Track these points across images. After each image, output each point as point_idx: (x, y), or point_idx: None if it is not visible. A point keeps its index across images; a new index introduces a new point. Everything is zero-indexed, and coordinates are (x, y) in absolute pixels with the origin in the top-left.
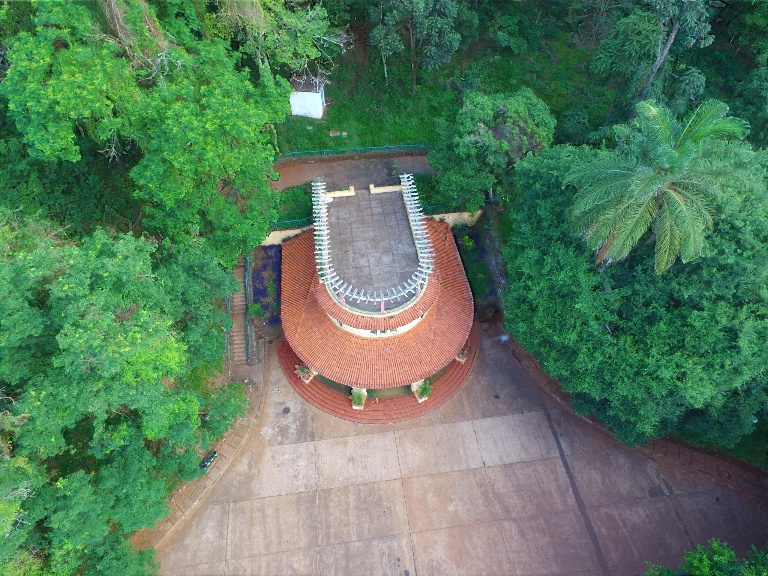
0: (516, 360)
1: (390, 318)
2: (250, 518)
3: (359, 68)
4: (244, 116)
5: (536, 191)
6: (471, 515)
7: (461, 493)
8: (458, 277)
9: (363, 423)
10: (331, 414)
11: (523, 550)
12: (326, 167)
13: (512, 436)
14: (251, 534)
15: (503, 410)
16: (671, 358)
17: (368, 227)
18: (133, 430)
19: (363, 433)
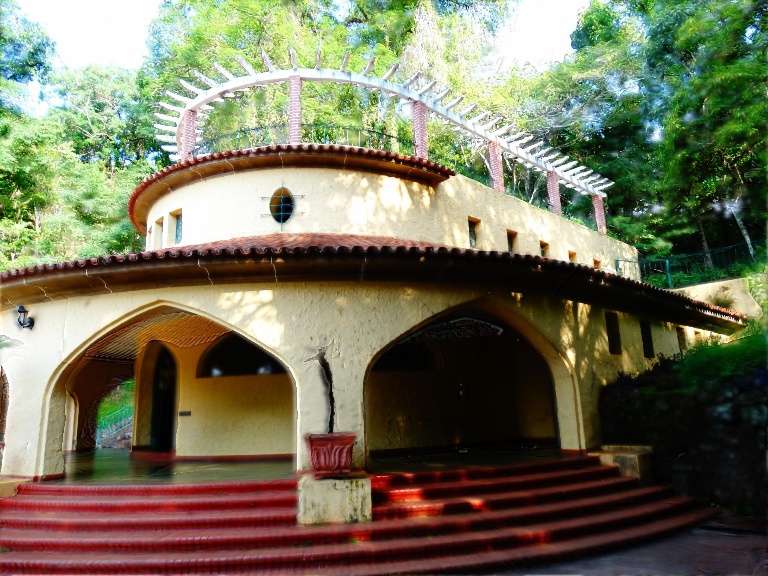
0: None
1: None
2: None
3: None
4: None
5: None
6: None
7: None
8: None
9: None
10: None
11: None
12: None
13: None
14: None
15: None
16: None
17: None
18: None
19: None
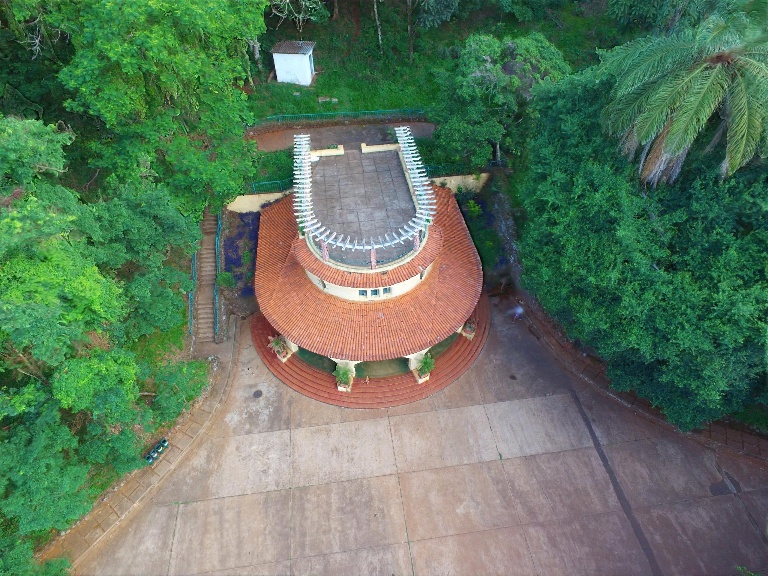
0: (534, 337)
1: (383, 274)
2: (203, 523)
3: (352, 38)
4: (200, 3)
5: (558, 110)
6: (486, 519)
7: (473, 491)
8: (463, 241)
9: (350, 408)
10: (312, 398)
11: (555, 563)
12: (313, 132)
13: (534, 422)
14: (203, 544)
15: (521, 392)
16: (748, 292)
17: (358, 184)
18: (42, 394)
19: (350, 419)
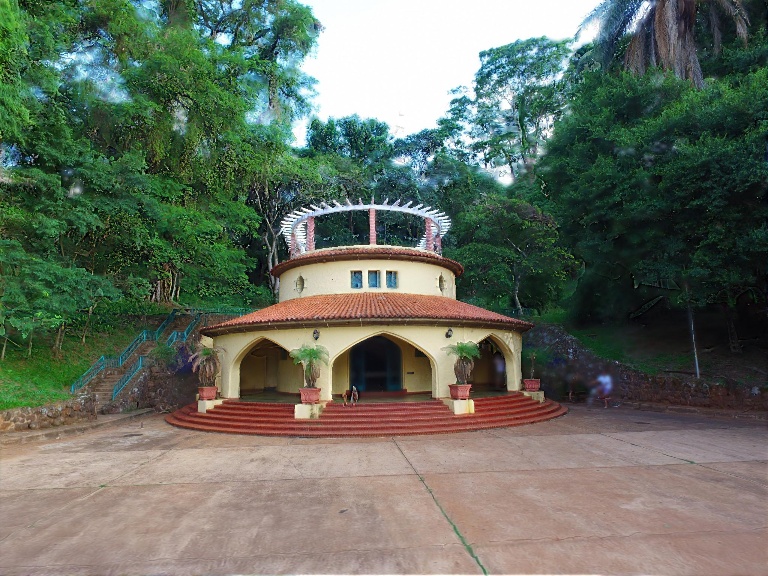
0: (650, 411)
1: None
2: None
3: None
4: None
5: None
6: (741, 513)
7: (651, 487)
8: None
9: (314, 437)
10: (238, 432)
11: None
12: None
13: (730, 440)
14: None
15: (670, 427)
16: None
17: None
18: None
19: (309, 442)
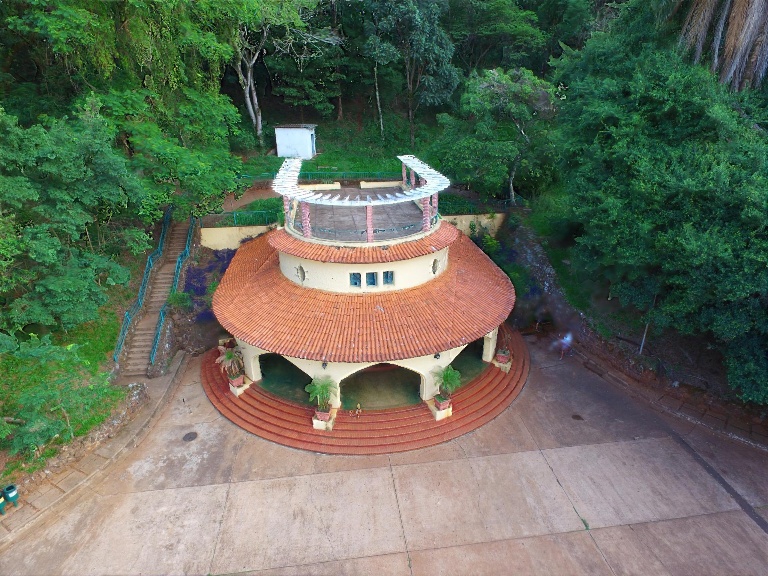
0: (593, 373)
1: (382, 249)
2: None
3: None
4: None
5: (588, 53)
6: None
7: None
8: (483, 261)
9: (331, 454)
10: (272, 440)
11: None
12: None
13: (627, 474)
14: None
15: (594, 435)
16: None
17: None
18: None
19: (329, 469)
